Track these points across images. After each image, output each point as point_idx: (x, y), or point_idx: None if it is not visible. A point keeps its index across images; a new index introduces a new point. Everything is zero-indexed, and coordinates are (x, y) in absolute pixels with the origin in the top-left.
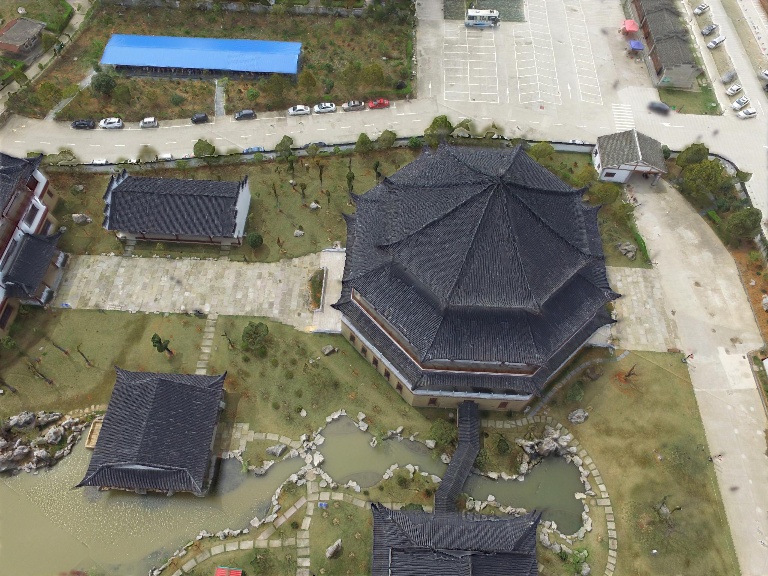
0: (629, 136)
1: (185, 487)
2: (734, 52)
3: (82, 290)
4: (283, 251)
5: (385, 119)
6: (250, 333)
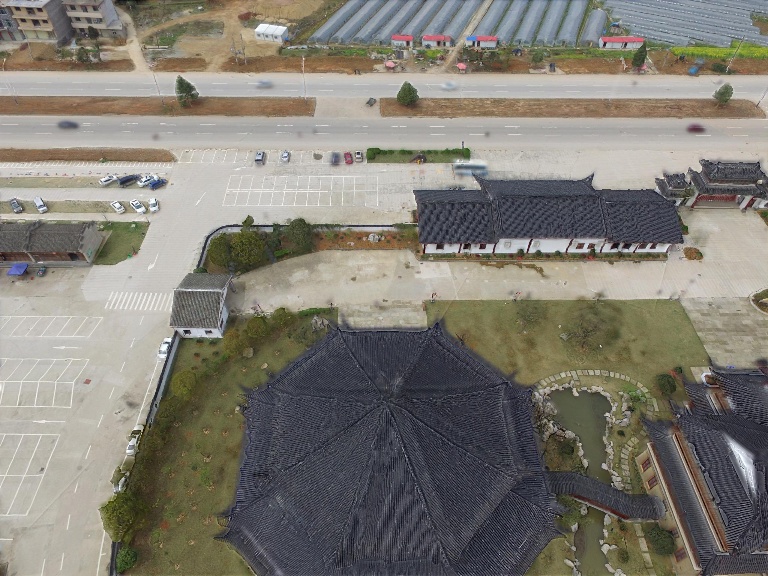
0: (182, 296)
1: None
2: (60, 196)
3: None
4: None
5: None
6: None
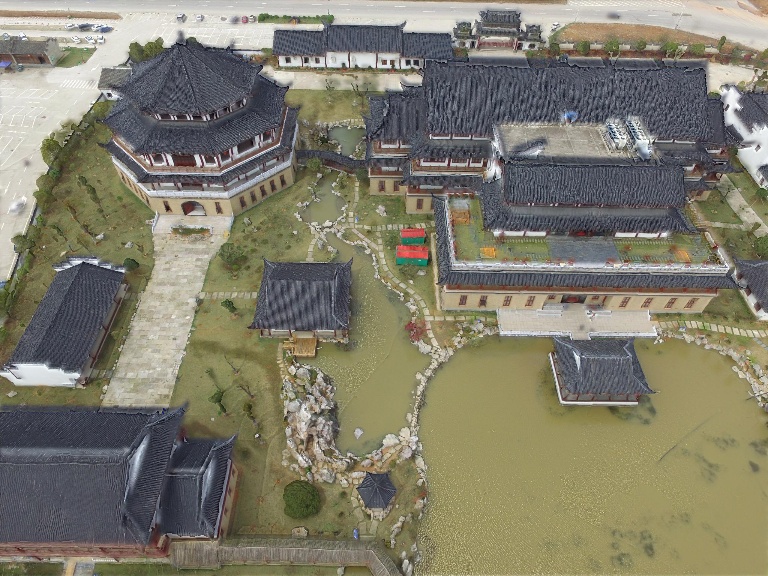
0: (107, 71)
1: (348, 271)
2: (37, 34)
3: (147, 404)
4: (145, 255)
5: (7, 201)
6: (228, 255)
